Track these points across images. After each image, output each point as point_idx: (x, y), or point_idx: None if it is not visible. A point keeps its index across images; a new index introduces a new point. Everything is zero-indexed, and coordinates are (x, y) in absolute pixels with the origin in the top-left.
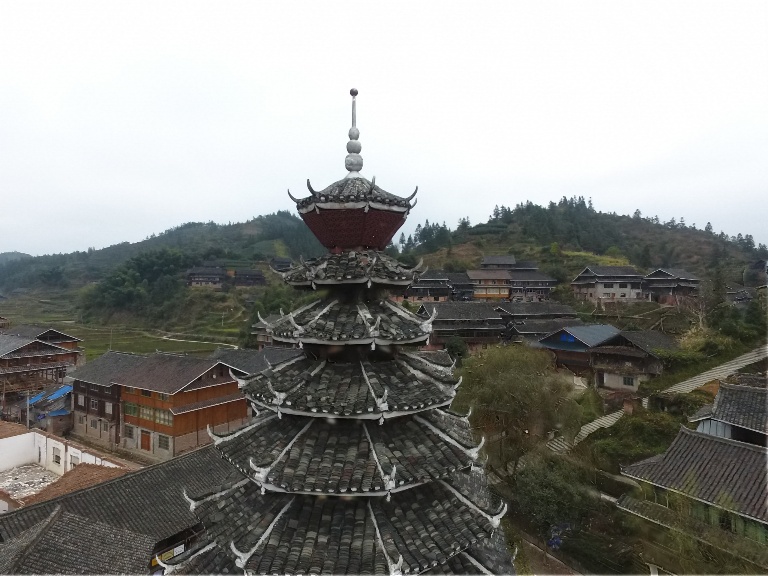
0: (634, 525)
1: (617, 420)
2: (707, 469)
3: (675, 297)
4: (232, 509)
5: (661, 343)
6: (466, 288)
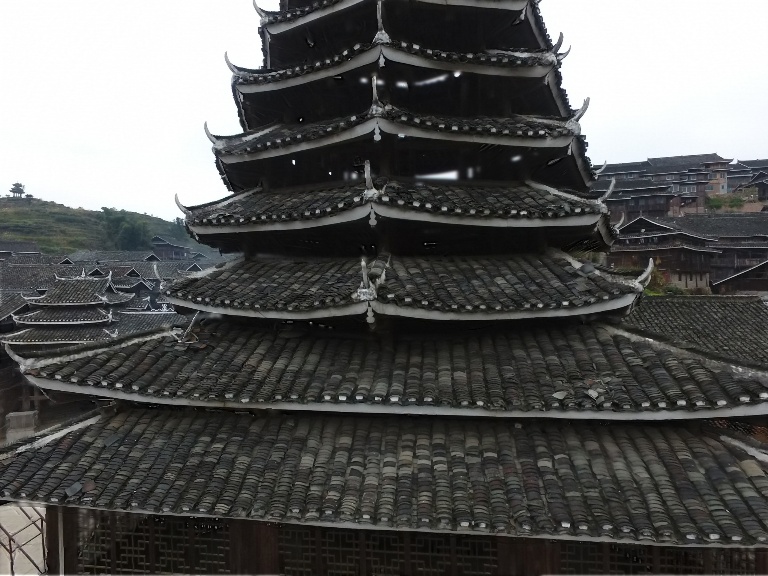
0: None
1: None
2: None
3: None
4: None
5: None
6: None
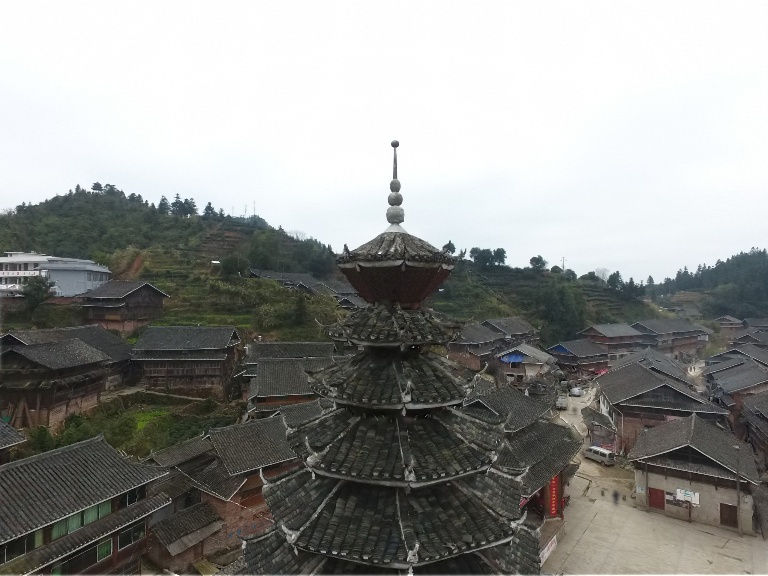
0: None
1: None
2: None
3: None
4: (514, 568)
5: None
6: None
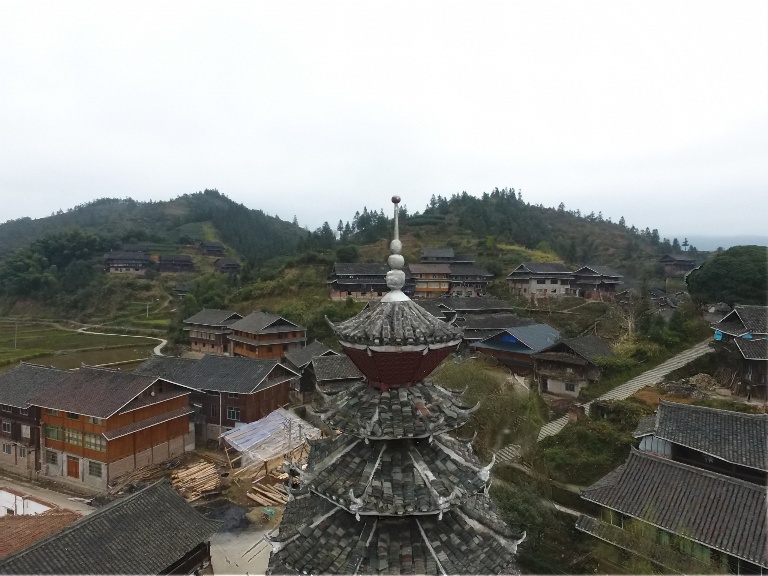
0: (583, 534)
1: (562, 428)
2: (658, 493)
3: (599, 293)
4: None
5: (598, 349)
6: (408, 282)
